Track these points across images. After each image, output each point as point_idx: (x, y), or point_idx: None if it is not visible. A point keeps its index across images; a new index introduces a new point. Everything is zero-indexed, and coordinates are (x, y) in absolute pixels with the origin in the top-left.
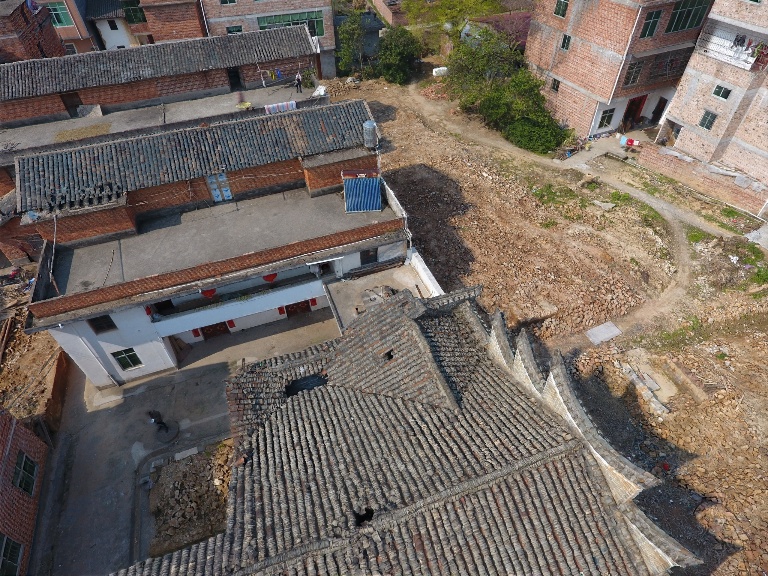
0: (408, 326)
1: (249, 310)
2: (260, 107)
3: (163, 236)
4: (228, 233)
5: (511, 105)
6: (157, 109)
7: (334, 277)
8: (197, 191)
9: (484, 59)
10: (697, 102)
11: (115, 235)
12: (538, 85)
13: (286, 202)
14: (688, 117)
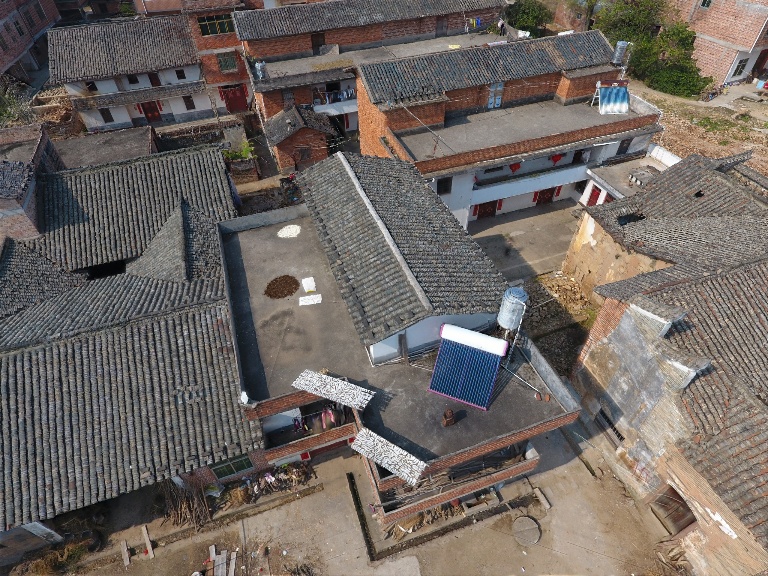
0: (710, 174)
1: (532, 188)
2: (480, 45)
3: (464, 129)
4: (515, 127)
5: None
6: (381, 50)
7: (595, 164)
8: (482, 97)
9: (646, 12)
10: None
11: (430, 127)
12: (690, 35)
13: (545, 109)
14: None
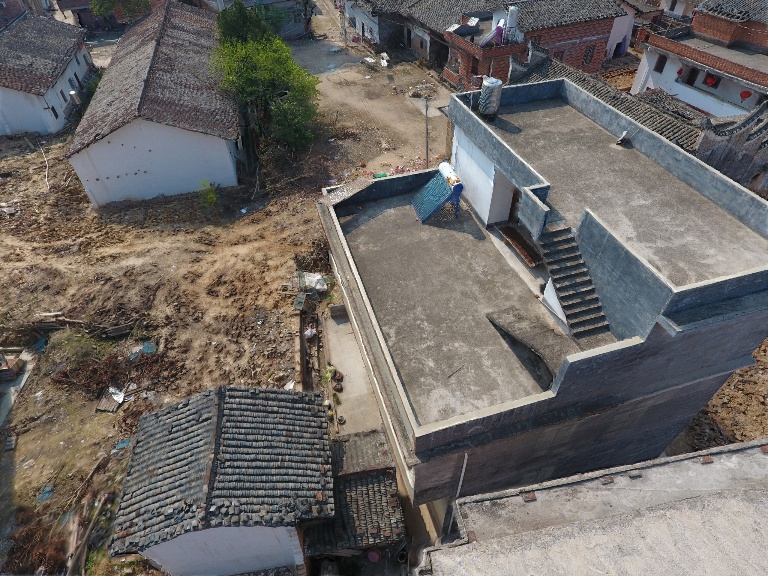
0: None
1: (715, 111)
2: None
3: (734, 53)
4: (762, 68)
5: None
6: None
7: None
8: None
9: None
10: None
11: (717, 41)
12: None
13: None
14: None
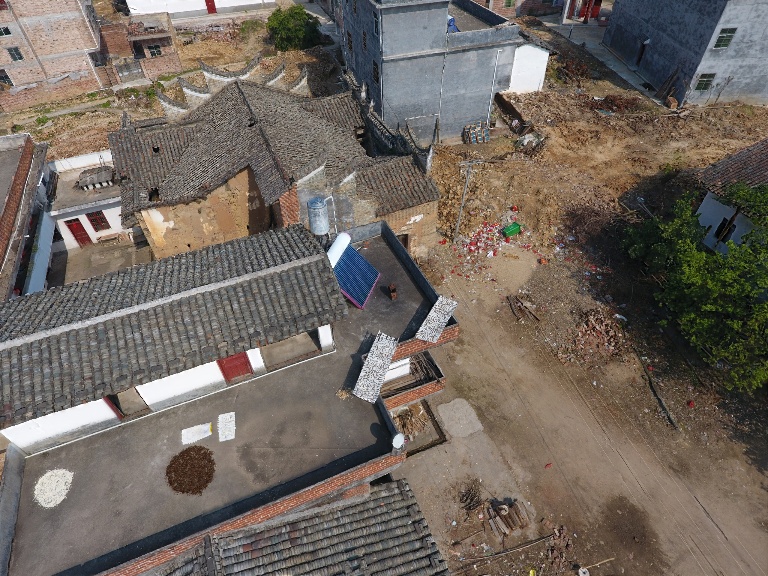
0: (140, 135)
1: (44, 261)
2: None
3: None
4: None
5: None
6: None
7: (46, 205)
8: None
9: None
10: None
11: None
12: None
13: None
14: (0, 61)
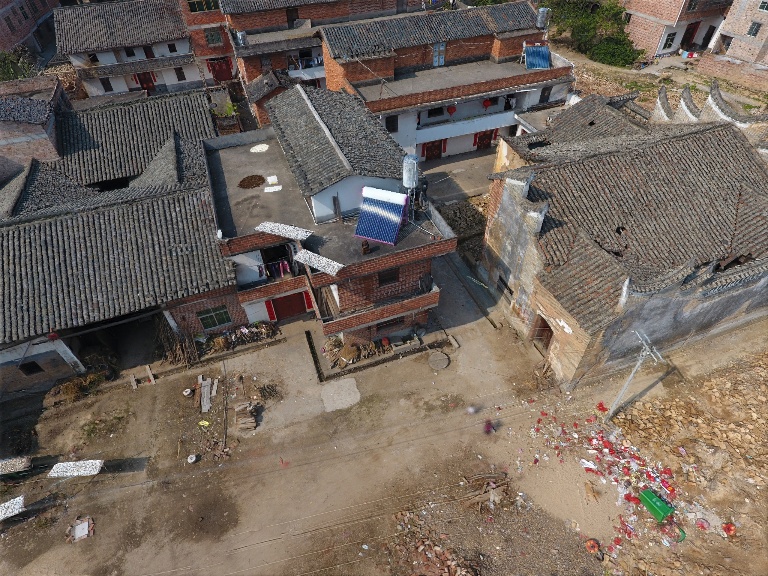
0: (602, 108)
1: (468, 130)
2: None
3: (411, 82)
4: (453, 80)
5: (596, 31)
6: None
7: (522, 110)
8: (427, 56)
9: None
10: (746, 17)
11: None
12: (621, 11)
13: (481, 66)
14: (738, 29)
